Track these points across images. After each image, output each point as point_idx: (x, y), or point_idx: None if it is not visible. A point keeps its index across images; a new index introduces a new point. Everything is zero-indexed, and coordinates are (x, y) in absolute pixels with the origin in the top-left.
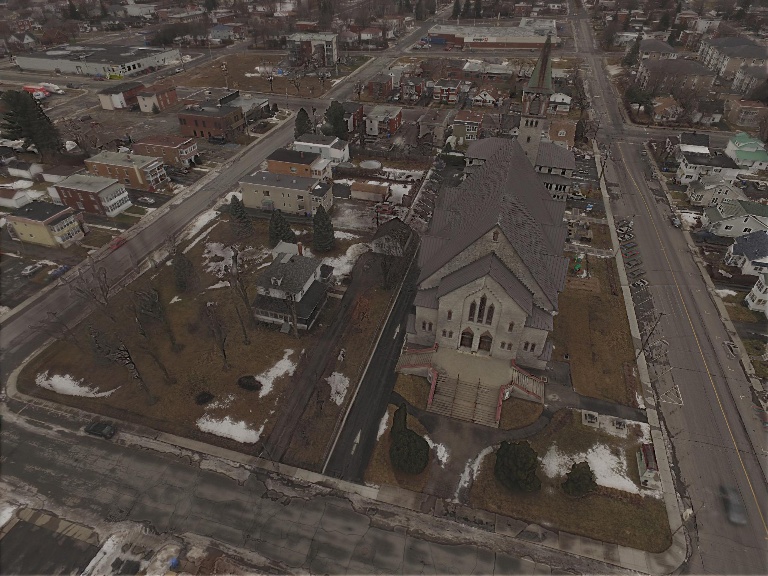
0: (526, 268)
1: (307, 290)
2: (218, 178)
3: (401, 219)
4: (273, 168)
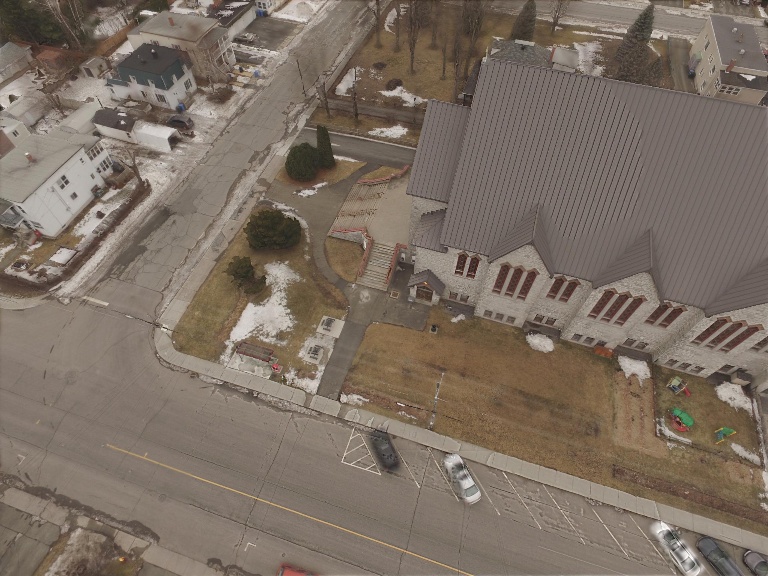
0: None
1: None
2: None
3: None
4: None
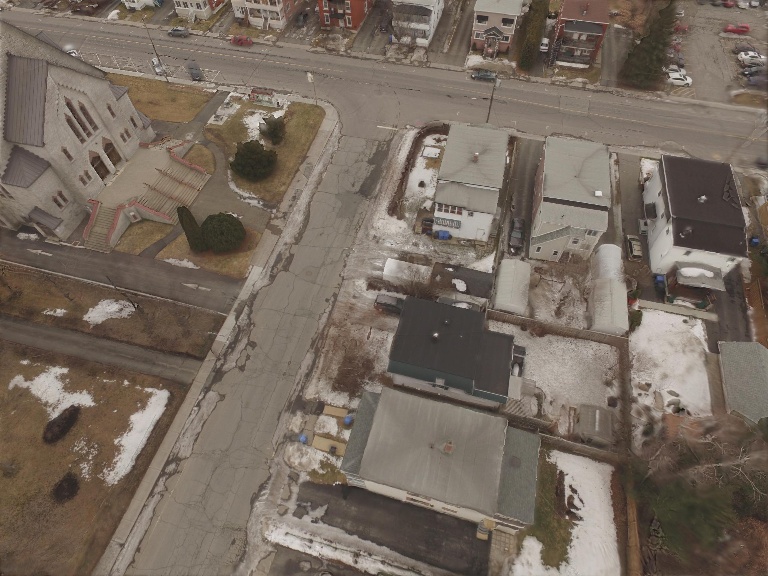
0: (49, 47)
1: None
2: None
3: None
4: None
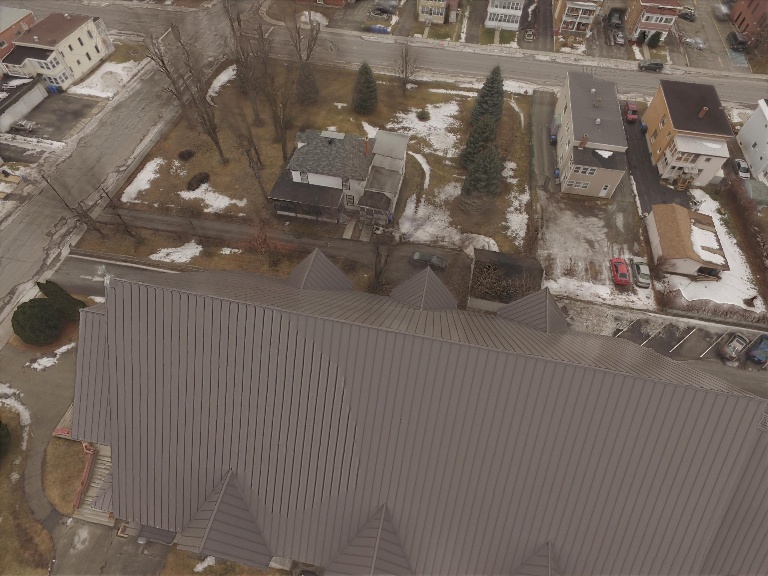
0: None
1: (317, 185)
2: (624, 71)
3: (591, 296)
4: (656, 100)
